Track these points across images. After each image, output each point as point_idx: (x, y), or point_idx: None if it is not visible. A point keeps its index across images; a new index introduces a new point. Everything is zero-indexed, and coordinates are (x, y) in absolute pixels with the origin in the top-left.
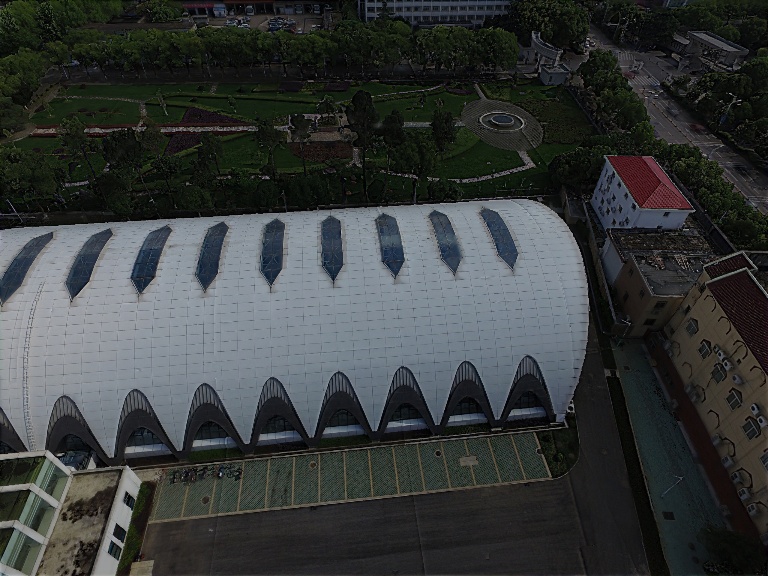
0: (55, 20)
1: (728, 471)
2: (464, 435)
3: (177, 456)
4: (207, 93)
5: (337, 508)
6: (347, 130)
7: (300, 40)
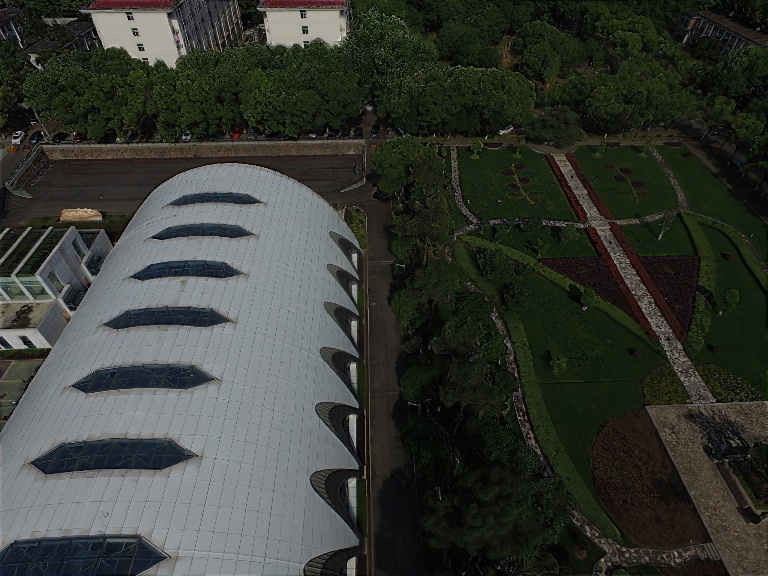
0: None
1: None
2: None
3: None
4: None
5: None
6: (760, 533)
7: None
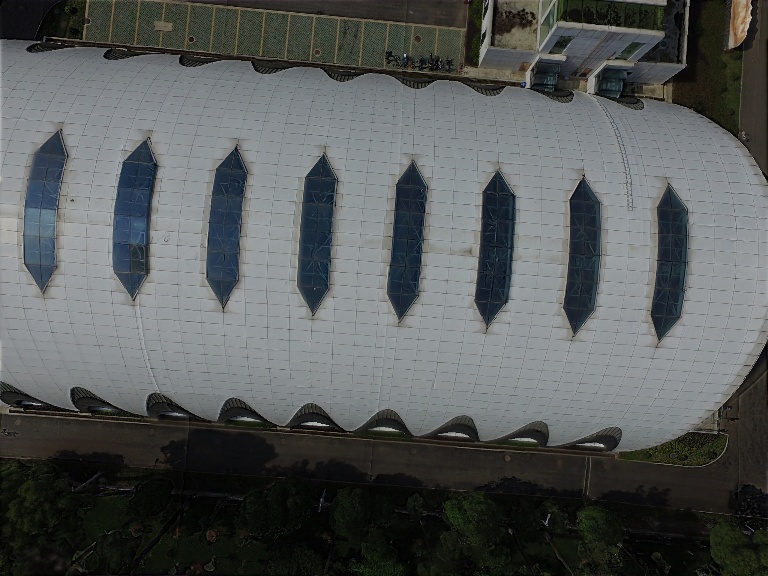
0: None
1: None
2: (158, 52)
3: None
4: None
5: (299, 8)
6: None
7: None
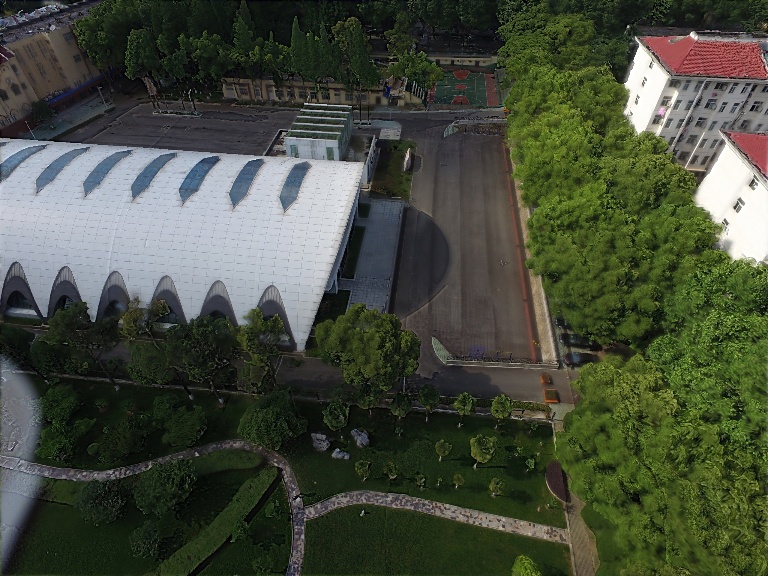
0: None
1: (1, 128)
2: None
3: None
4: None
5: None
6: None
7: None
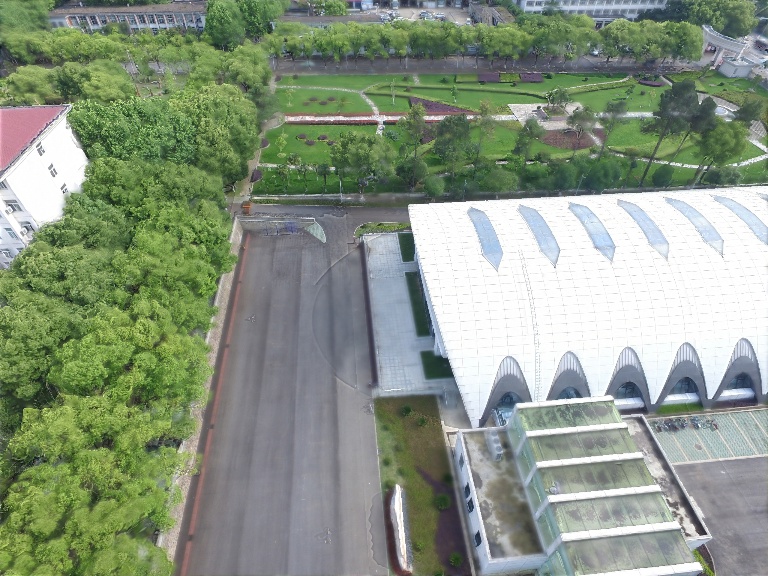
0: (259, 13)
1: None
2: None
3: (649, 409)
4: (414, 84)
5: None
6: None
7: (502, 33)
